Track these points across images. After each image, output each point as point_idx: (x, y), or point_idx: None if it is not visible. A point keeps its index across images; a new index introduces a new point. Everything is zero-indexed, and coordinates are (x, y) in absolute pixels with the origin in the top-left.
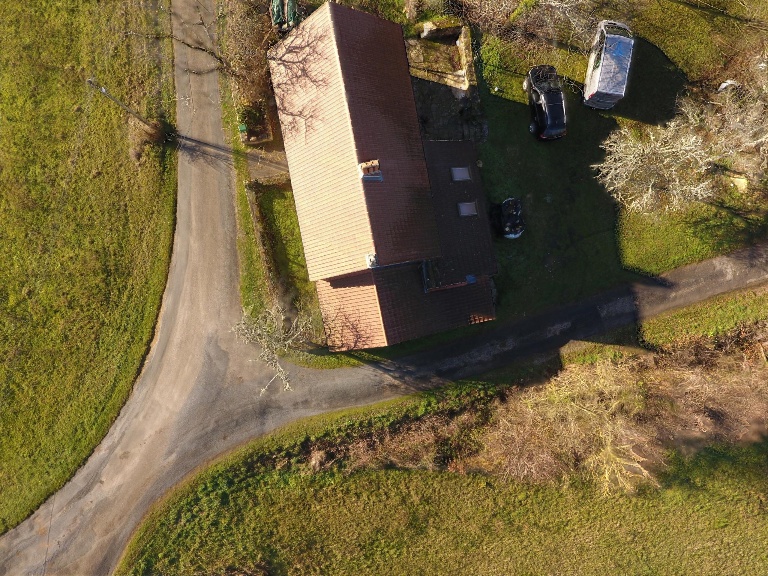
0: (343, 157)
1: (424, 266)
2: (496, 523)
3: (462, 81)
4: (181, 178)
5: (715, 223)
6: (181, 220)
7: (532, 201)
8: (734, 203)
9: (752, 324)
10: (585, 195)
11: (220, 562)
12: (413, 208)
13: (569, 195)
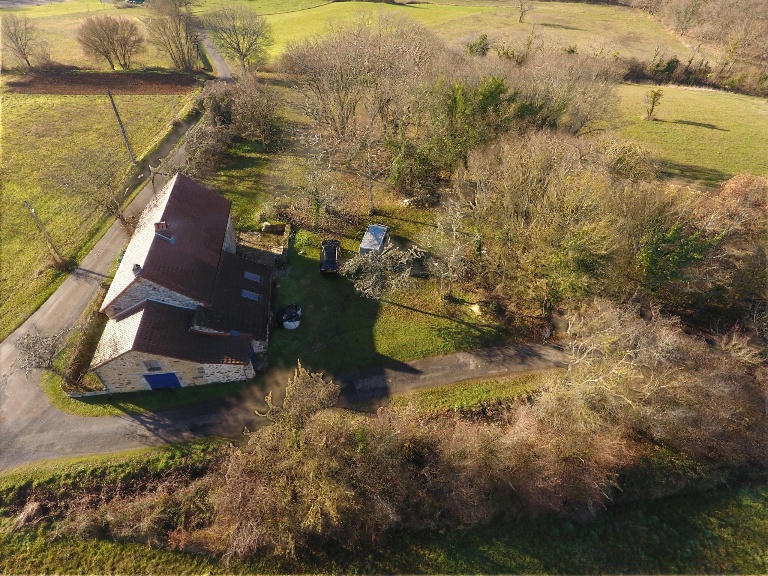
0: None
1: None
2: None
3: None
4: (61, 287)
5: (456, 330)
6: (42, 309)
7: (313, 309)
8: (472, 320)
9: (496, 404)
10: (354, 308)
11: None
12: (194, 268)
13: (342, 307)
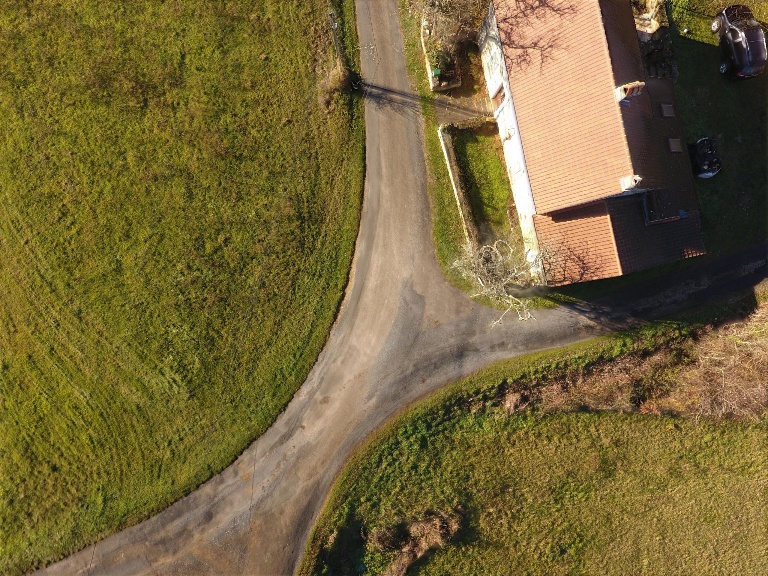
0: (594, 83)
1: (645, 199)
2: (682, 465)
3: (648, 24)
4: (369, 126)
5: None
6: (371, 167)
7: (723, 141)
8: None
9: None
10: None
11: (419, 506)
12: (647, 137)
13: (760, 134)
